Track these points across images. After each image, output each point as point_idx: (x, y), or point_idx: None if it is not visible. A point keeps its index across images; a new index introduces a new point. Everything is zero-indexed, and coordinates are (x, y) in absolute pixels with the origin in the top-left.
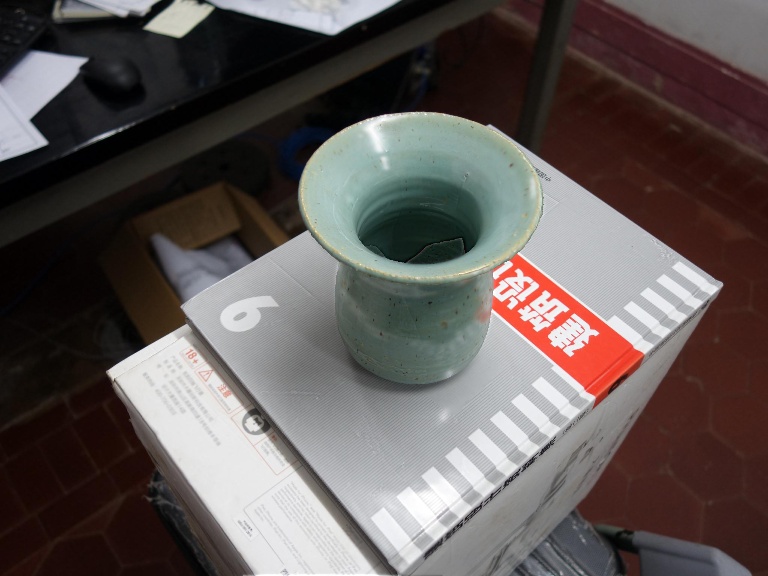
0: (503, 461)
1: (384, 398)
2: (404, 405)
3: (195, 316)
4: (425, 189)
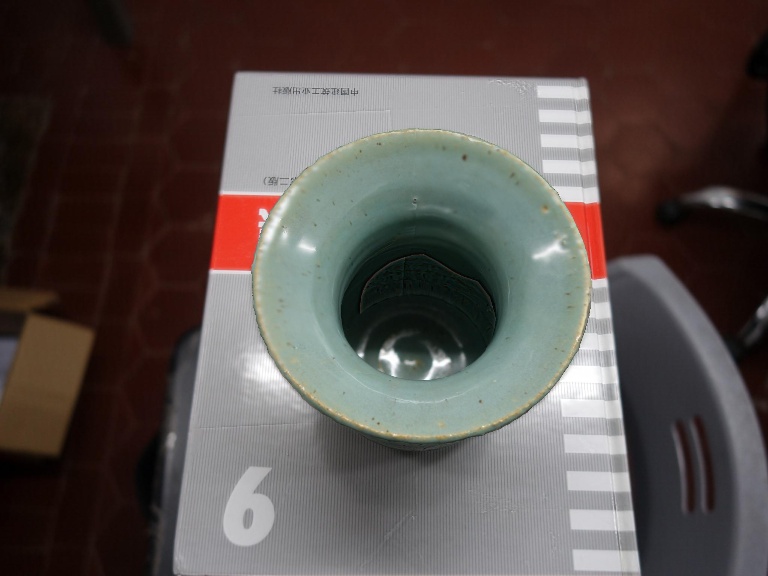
0: (605, 407)
1: (465, 455)
2: (487, 443)
3: (204, 568)
4: (369, 246)
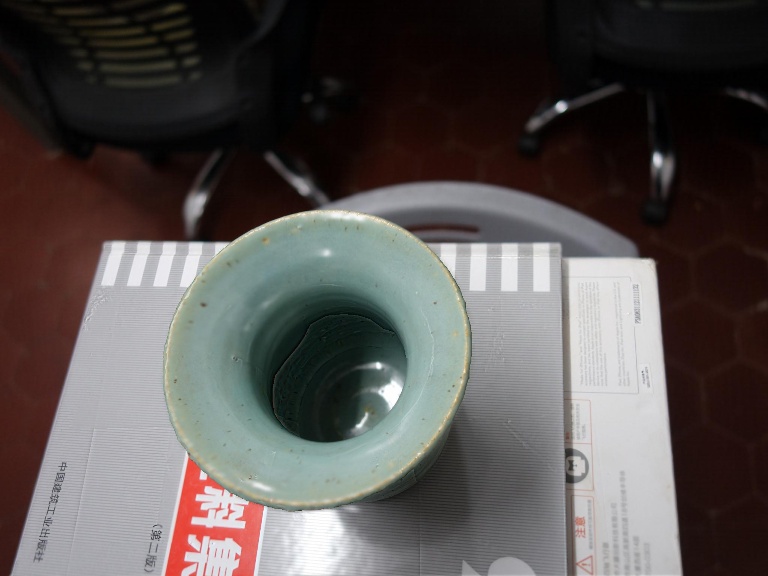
0: None
1: None
2: None
3: None
4: None
